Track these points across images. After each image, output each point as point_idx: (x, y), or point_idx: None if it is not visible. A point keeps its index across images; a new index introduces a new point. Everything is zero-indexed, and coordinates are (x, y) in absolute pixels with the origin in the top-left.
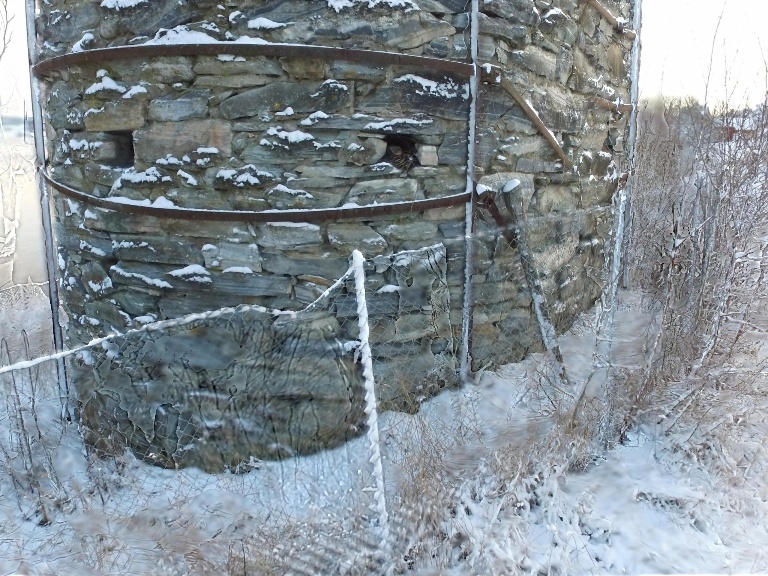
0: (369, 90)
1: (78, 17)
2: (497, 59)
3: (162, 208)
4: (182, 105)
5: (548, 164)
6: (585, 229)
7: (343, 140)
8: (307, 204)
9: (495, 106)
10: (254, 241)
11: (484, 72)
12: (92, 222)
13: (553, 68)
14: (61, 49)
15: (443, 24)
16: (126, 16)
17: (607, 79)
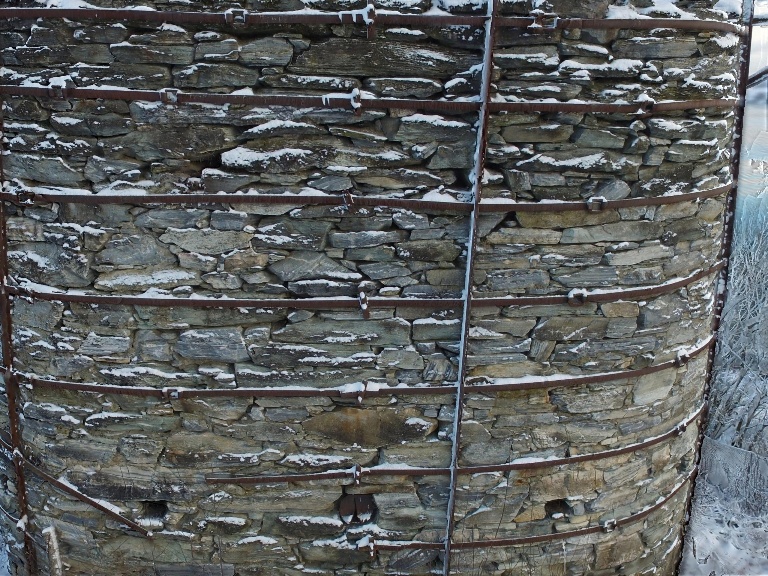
0: None
1: None
2: None
3: None
4: None
5: (112, 522)
6: None
7: None
8: None
9: None
10: None
11: None
12: None
13: (108, 455)
14: None
15: None
16: None
17: (317, 447)
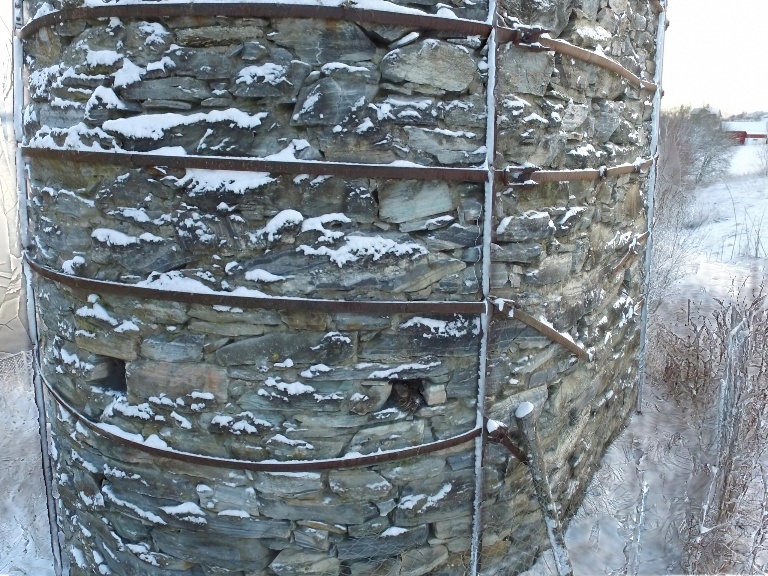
0: (374, 335)
1: (69, 236)
2: (510, 285)
3: (155, 448)
4: (176, 349)
5: (562, 363)
6: (599, 389)
7: (346, 391)
8: (307, 454)
9: (507, 332)
10: (251, 484)
11: (496, 309)
12: (83, 438)
13: (569, 267)
14: (52, 257)
15: (453, 262)
16: (117, 253)
17: (624, 226)
